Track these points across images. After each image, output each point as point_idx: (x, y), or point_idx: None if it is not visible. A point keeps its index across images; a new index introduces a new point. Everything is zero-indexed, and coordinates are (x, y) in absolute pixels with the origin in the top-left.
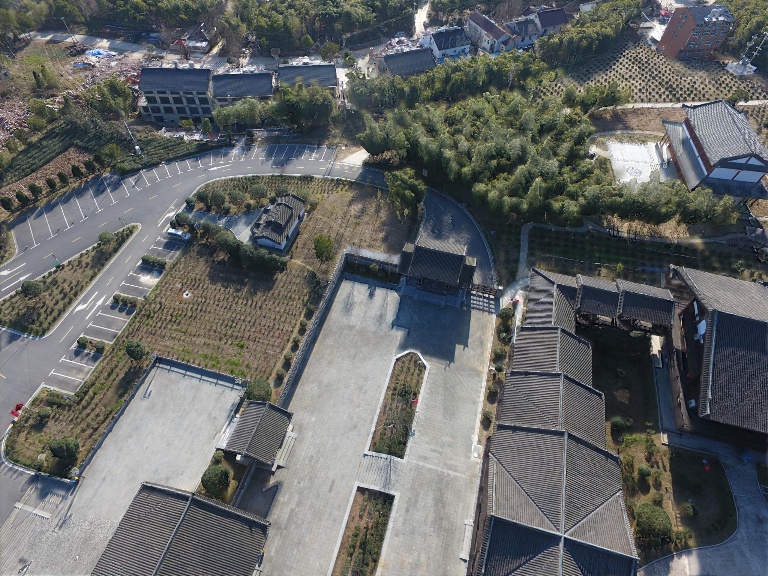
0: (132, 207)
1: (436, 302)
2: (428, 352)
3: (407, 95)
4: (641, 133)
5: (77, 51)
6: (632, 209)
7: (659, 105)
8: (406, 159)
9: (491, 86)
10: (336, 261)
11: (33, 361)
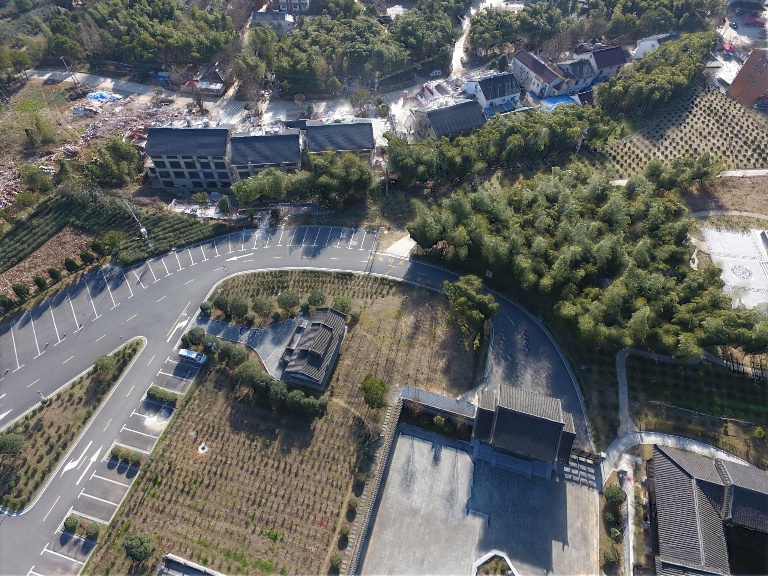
0: (136, 313)
1: (520, 471)
2: (517, 553)
3: (459, 165)
4: (739, 215)
5: (78, 94)
6: (765, 345)
7: (749, 173)
8: (466, 257)
9: (553, 150)
10: (388, 402)
11: (7, 552)
